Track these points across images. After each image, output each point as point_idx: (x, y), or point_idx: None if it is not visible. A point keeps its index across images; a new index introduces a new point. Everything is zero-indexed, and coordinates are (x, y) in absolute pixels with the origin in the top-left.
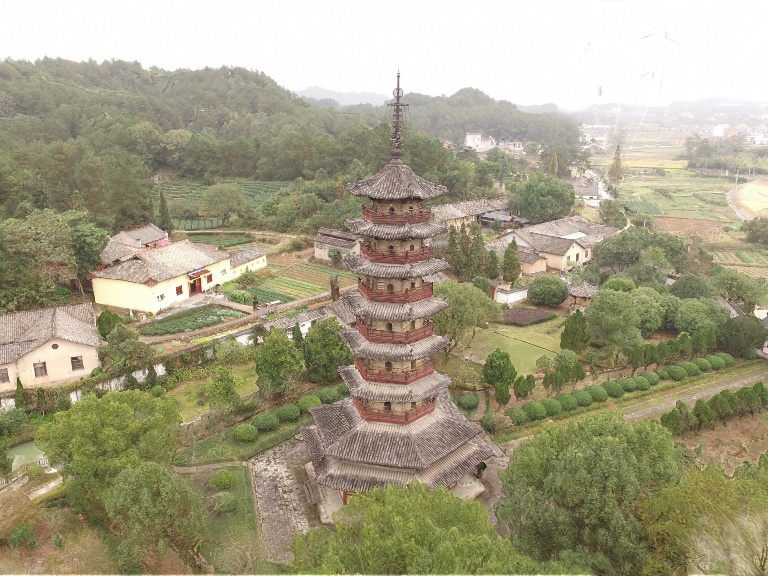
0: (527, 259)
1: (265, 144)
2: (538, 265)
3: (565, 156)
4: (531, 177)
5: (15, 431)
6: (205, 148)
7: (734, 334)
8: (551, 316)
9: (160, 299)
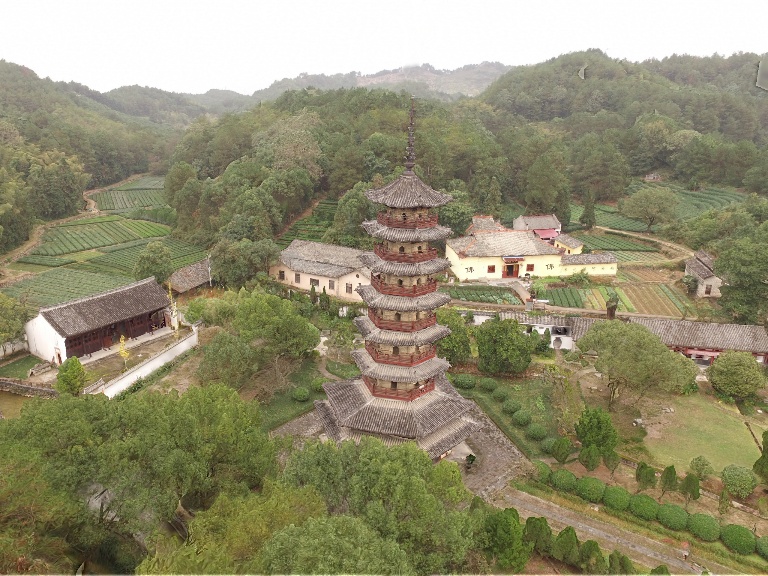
0: None
1: (767, 151)
2: None
3: None
4: None
5: (308, 316)
6: (701, 151)
7: None
8: None
9: (469, 271)
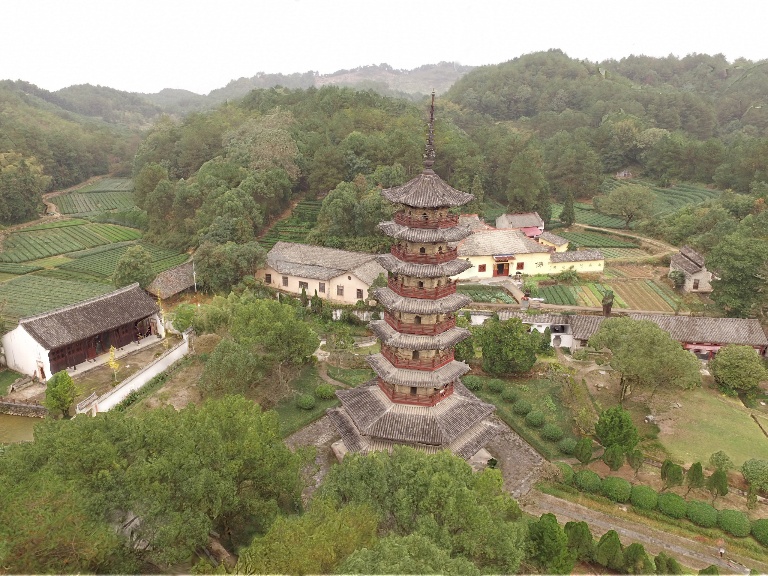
0: None
1: (736, 149)
2: None
3: None
4: None
5: None
6: (671, 148)
7: None
8: None
9: None
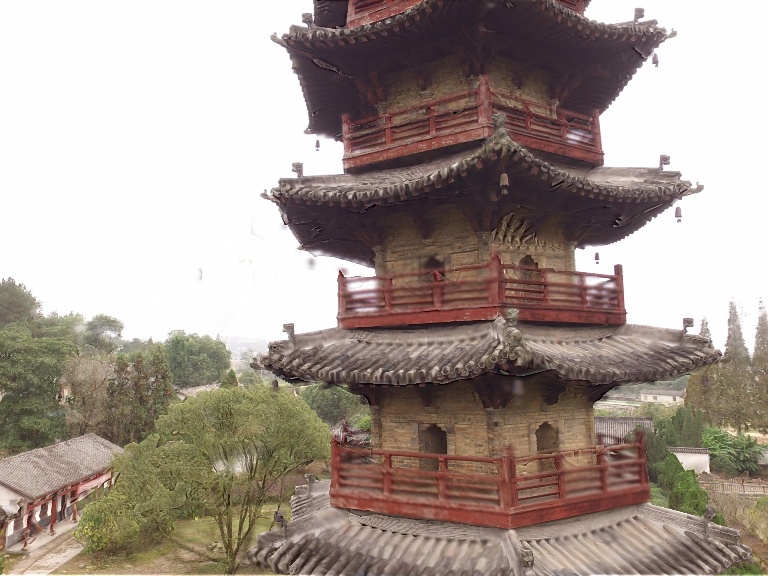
0: None
1: None
2: None
3: None
4: (172, 333)
5: None
6: None
7: None
8: None
9: None
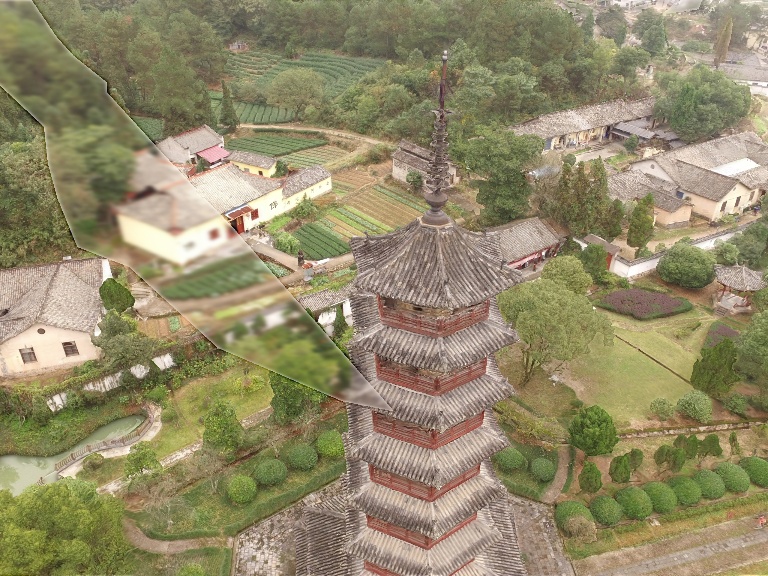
0: (665, 205)
1: (356, 8)
2: (679, 213)
3: (743, 19)
4: (691, 74)
5: None
6: (287, 11)
7: None
8: (685, 308)
9: None
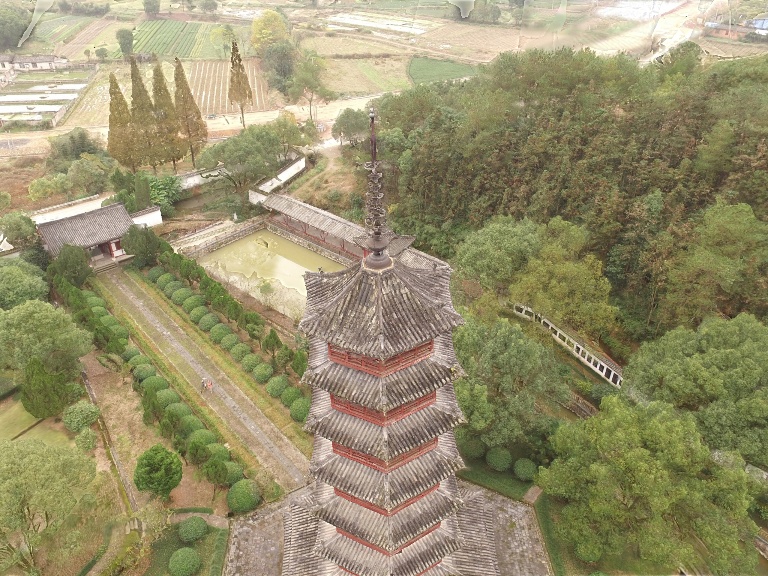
0: None
1: None
2: None
3: None
4: None
5: None
6: None
7: (80, 269)
8: None
9: None
